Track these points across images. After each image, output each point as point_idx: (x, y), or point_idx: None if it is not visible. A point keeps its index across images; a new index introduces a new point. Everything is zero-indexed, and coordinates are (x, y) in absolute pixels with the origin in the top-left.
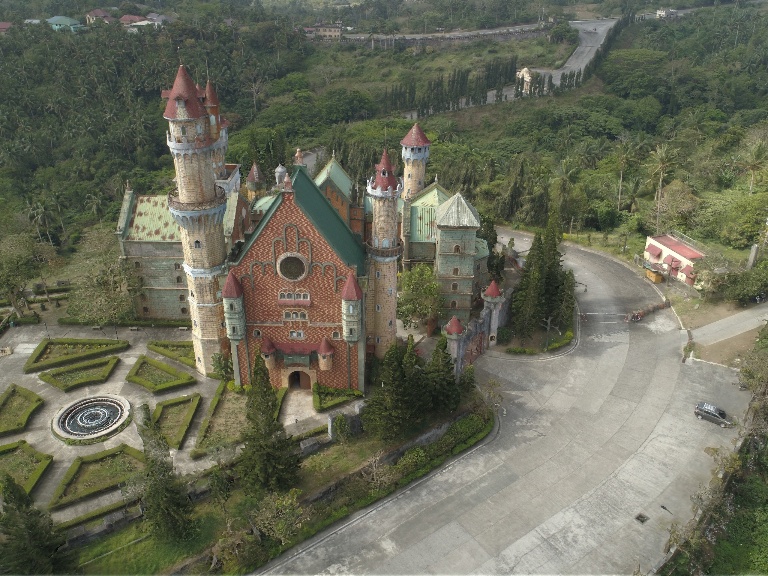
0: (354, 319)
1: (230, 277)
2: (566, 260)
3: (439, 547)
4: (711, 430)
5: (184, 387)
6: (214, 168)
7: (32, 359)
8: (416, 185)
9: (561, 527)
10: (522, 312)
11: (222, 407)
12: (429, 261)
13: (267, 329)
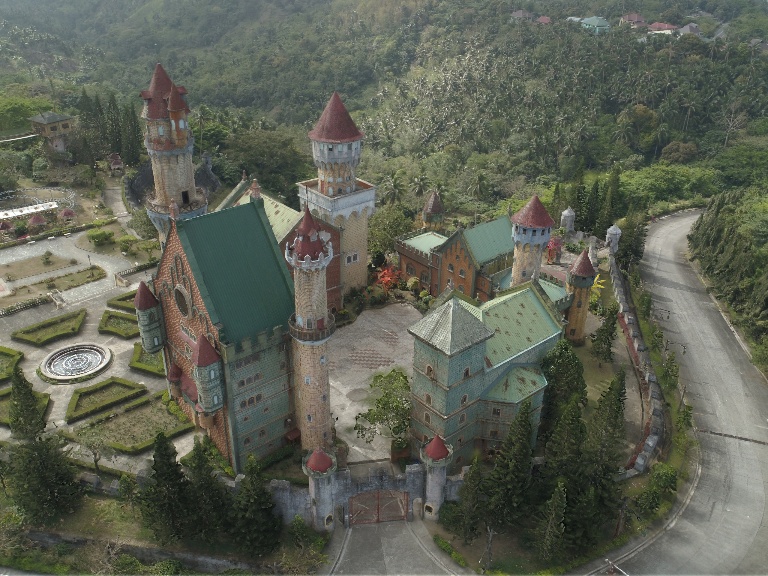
0: (200, 386)
1: (140, 287)
2: (760, 481)
3: None
4: None
5: (154, 375)
6: (331, 182)
7: (121, 296)
8: (519, 275)
9: None
10: (488, 501)
11: (142, 409)
12: None
13: (179, 355)
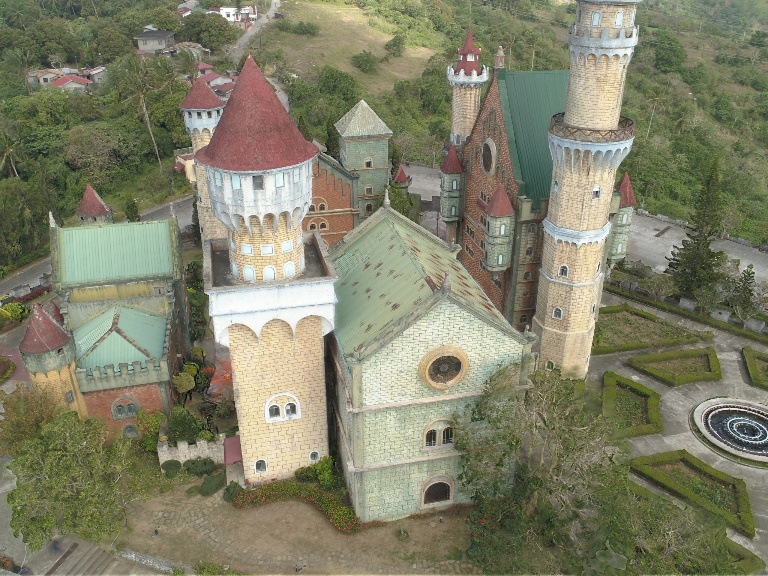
0: None
1: None
2: None
3: (643, 251)
4: None
5: None
6: None
7: None
8: None
9: None
10: None
11: None
12: None
13: None
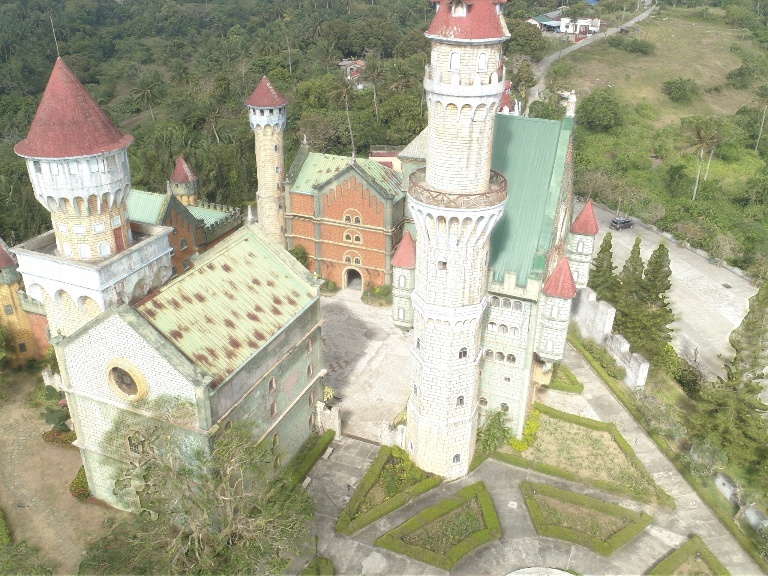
0: None
1: None
2: None
3: None
4: (634, 232)
5: None
6: (127, 219)
7: None
8: (282, 159)
9: (739, 318)
10: None
11: None
12: (402, 221)
13: None
